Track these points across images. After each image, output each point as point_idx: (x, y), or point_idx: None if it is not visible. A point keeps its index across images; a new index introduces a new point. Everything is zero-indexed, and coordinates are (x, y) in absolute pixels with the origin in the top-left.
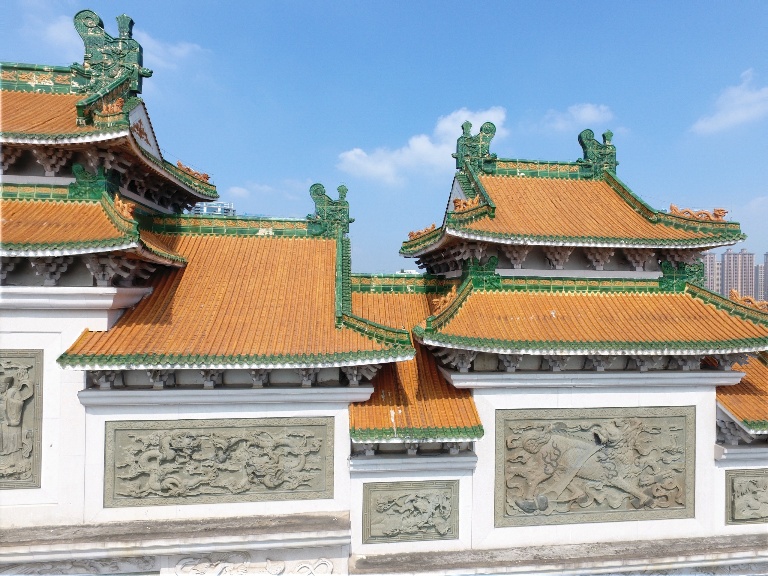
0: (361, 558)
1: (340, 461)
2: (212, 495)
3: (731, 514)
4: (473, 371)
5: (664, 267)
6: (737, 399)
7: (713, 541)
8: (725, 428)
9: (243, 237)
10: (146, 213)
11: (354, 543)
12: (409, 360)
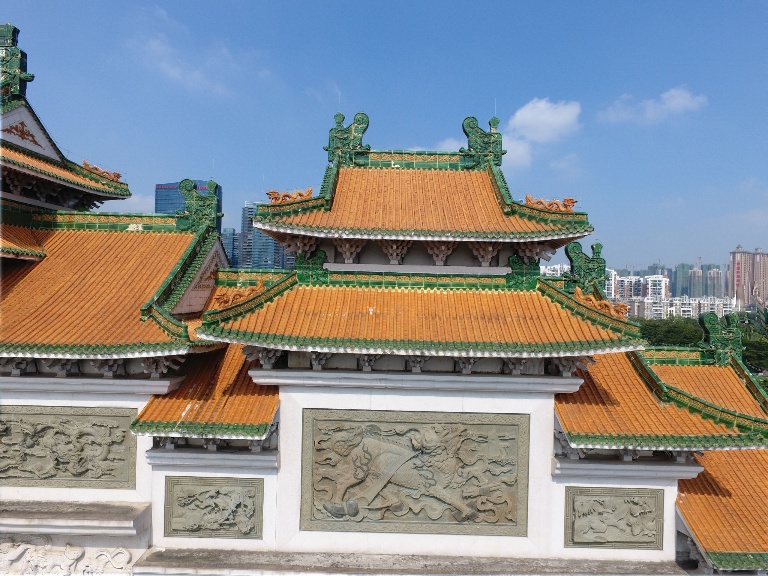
0: (160, 550)
1: (142, 453)
2: (21, 478)
3: (571, 535)
4: (284, 368)
5: (512, 262)
6: (578, 409)
7: (544, 563)
8: (563, 440)
9: (114, 232)
10: (20, 210)
11: (156, 535)
12: (240, 355)
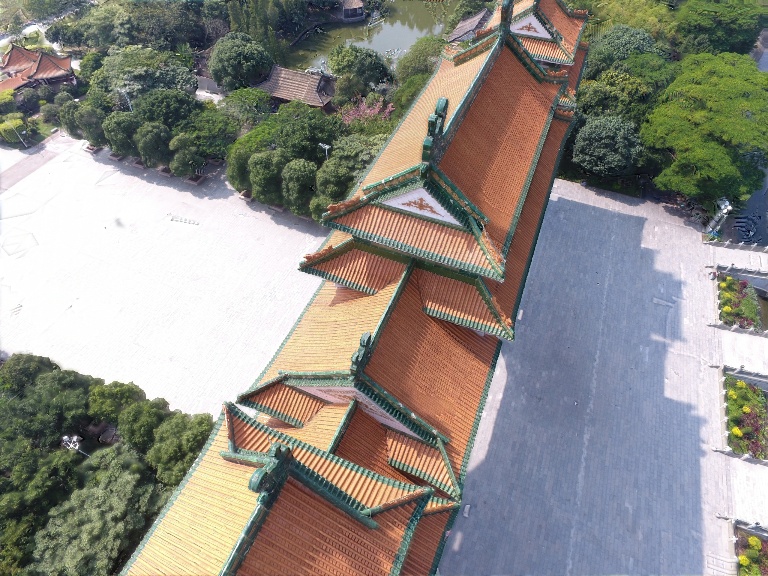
0: None
1: None
2: None
3: None
4: None
5: None
6: None
7: None
8: None
9: None
10: (402, 255)
11: None
12: None
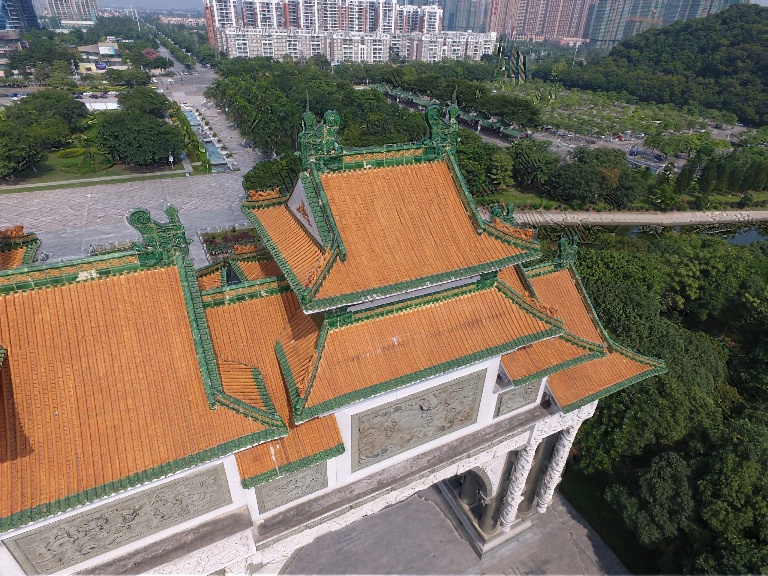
0: (260, 523)
1: (234, 484)
2: (130, 538)
3: (497, 413)
4: None
5: None
6: (513, 357)
7: (484, 432)
8: (503, 375)
9: (60, 286)
10: None
11: (253, 517)
12: (277, 384)
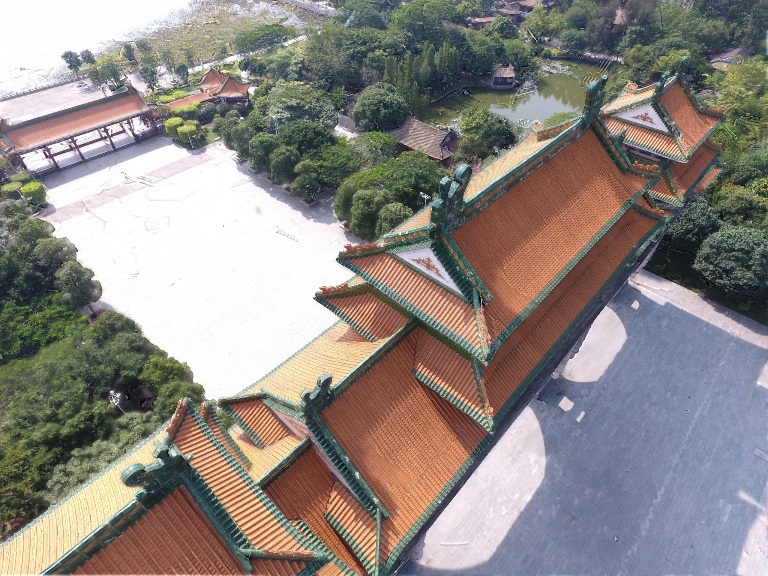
0: None
1: None
2: None
3: None
4: None
5: None
6: None
7: None
8: None
9: None
10: None
11: None
12: None
